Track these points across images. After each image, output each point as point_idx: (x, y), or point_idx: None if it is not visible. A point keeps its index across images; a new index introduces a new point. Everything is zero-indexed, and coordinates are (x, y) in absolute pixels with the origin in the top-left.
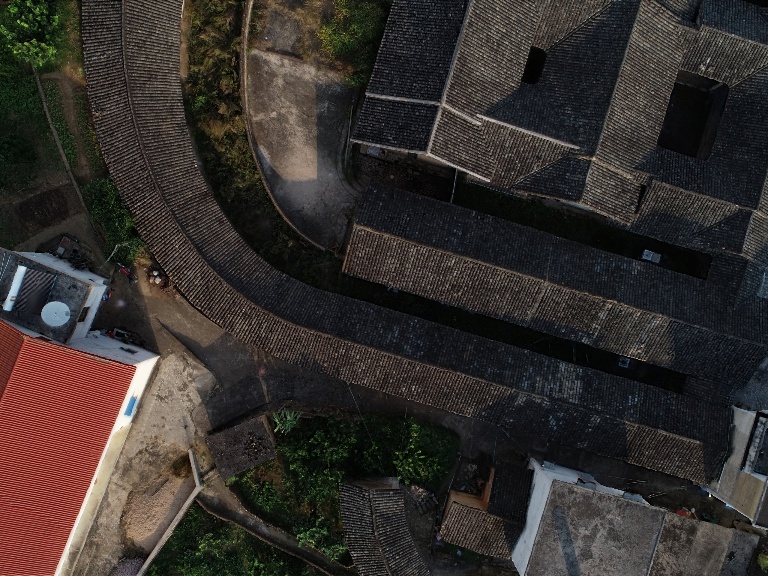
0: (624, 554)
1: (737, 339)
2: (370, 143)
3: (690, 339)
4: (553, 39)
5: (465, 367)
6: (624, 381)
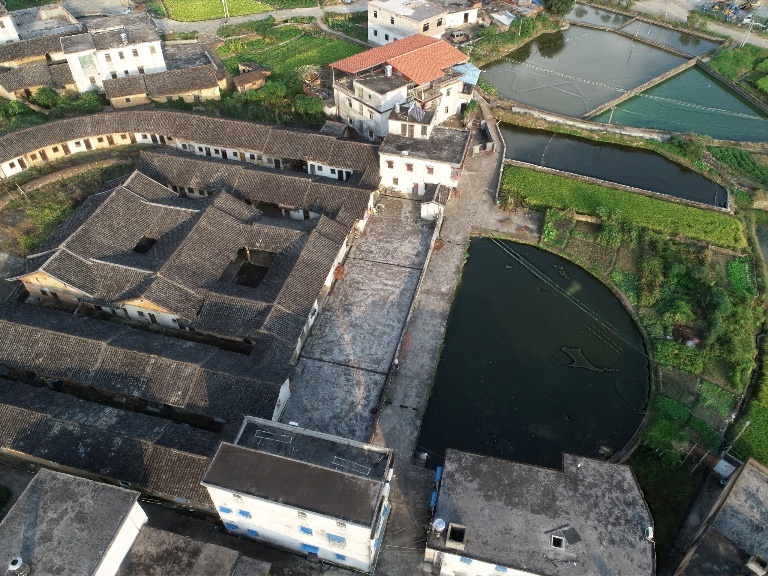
0: (85, 536)
1: (253, 381)
2: (15, 277)
3: (218, 385)
4: (162, 233)
5: (17, 403)
6: (158, 419)
